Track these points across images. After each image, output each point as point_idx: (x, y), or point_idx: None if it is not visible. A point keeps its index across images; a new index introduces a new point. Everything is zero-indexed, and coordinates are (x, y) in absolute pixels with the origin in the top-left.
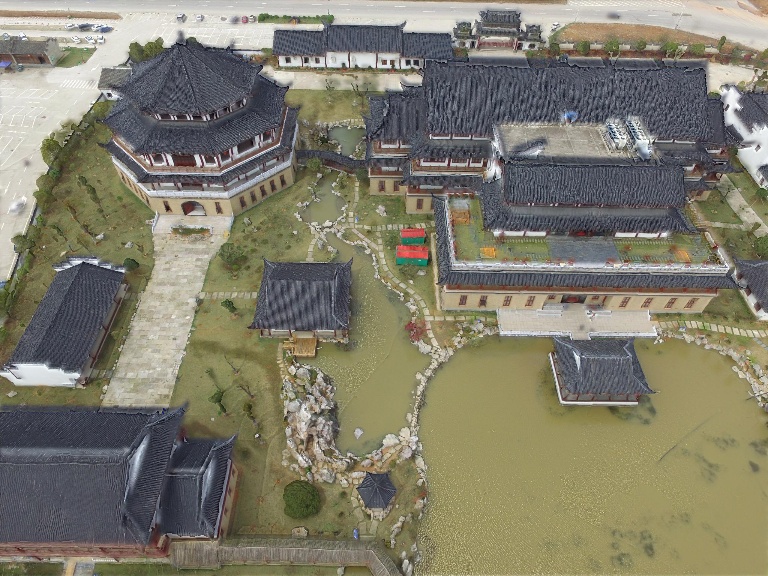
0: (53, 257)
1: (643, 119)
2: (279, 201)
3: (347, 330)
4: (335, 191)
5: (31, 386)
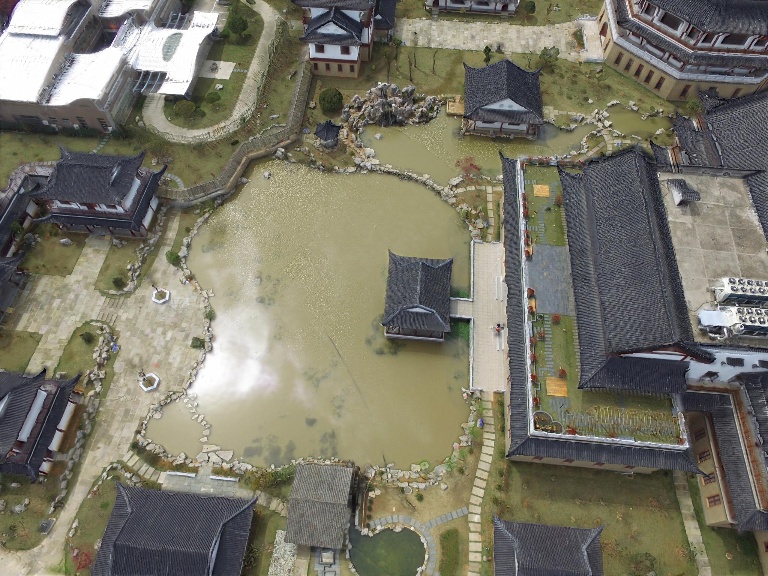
0: None
1: None
2: (635, 90)
3: (474, 134)
4: (663, 131)
5: None
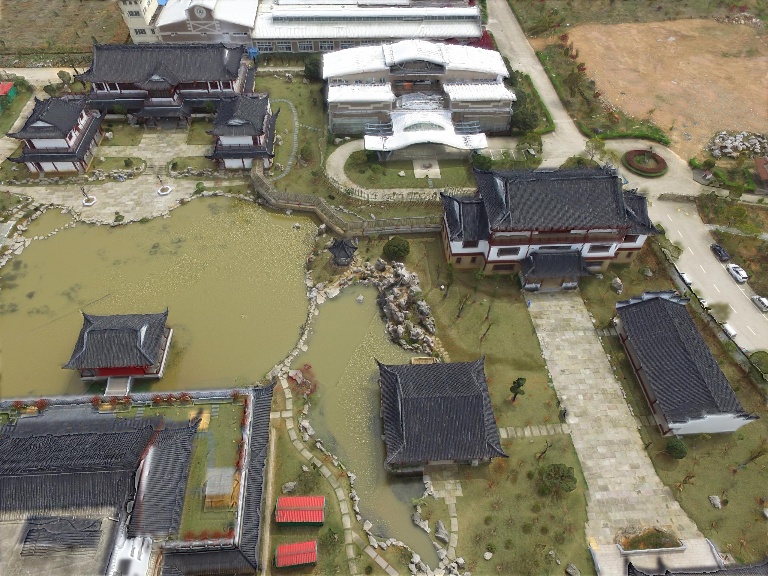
0: None
1: None
2: None
3: None
4: None
5: None
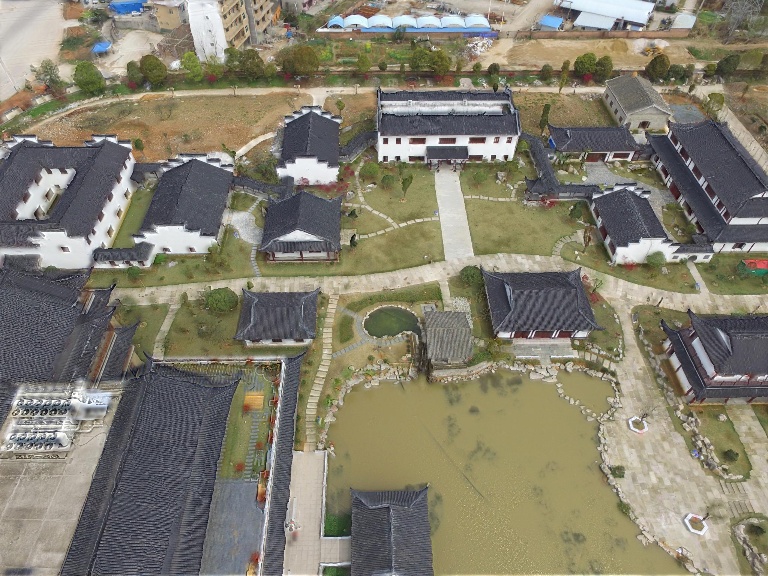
0: None
1: (6, 385)
2: None
3: None
4: None
5: None
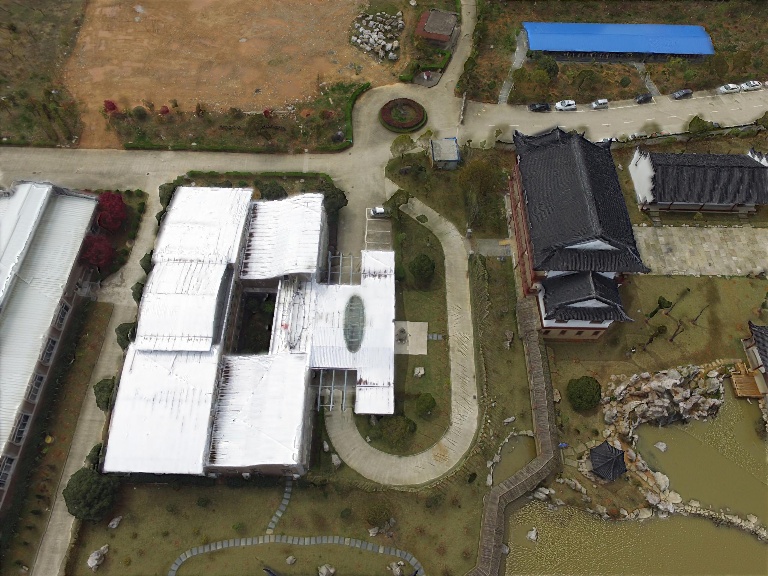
0: (762, 149)
1: None
2: None
3: None
4: None
5: (631, 176)
